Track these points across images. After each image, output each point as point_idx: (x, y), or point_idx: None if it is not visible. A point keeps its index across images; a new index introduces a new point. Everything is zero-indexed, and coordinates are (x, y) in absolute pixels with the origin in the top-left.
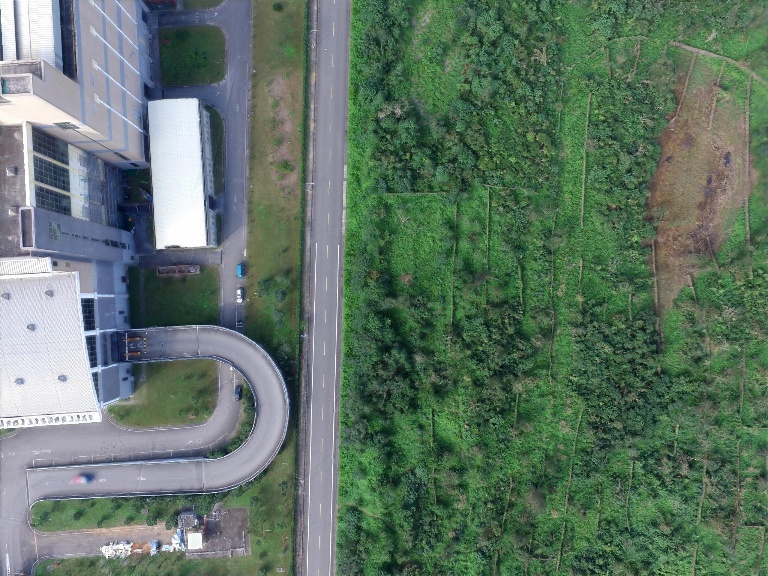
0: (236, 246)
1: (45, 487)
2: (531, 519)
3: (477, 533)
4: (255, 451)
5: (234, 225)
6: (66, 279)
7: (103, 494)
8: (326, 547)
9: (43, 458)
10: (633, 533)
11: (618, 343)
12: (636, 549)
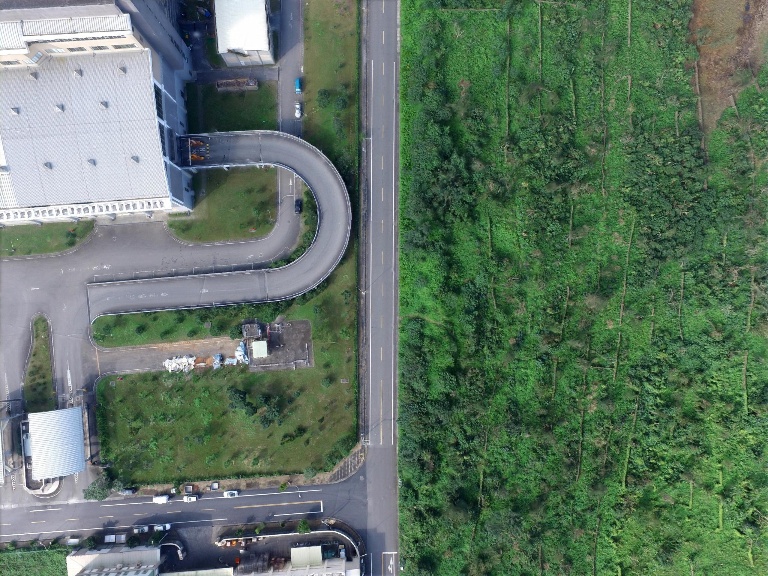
0: (293, 63)
1: (106, 303)
2: (587, 329)
3: (536, 341)
4: (318, 259)
5: (291, 42)
6: (139, 56)
7: (165, 307)
8: (388, 358)
9: (104, 274)
10: (686, 342)
11: (667, 157)
12: (689, 357)
